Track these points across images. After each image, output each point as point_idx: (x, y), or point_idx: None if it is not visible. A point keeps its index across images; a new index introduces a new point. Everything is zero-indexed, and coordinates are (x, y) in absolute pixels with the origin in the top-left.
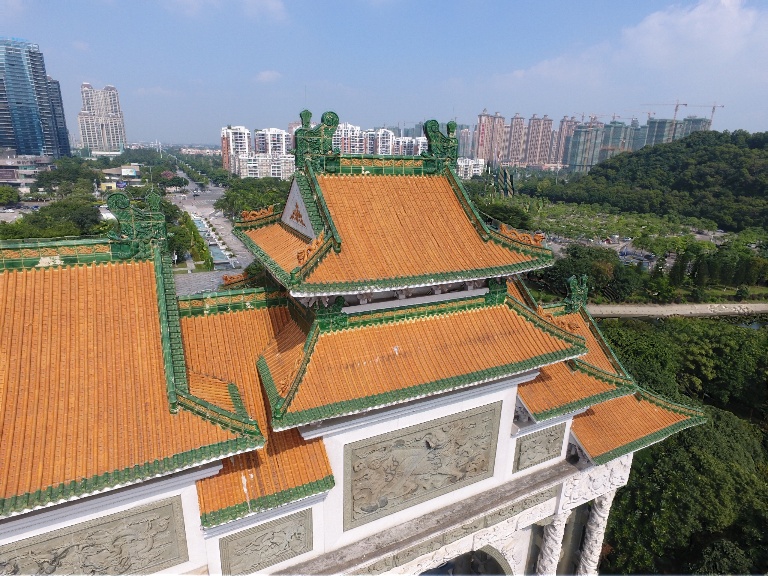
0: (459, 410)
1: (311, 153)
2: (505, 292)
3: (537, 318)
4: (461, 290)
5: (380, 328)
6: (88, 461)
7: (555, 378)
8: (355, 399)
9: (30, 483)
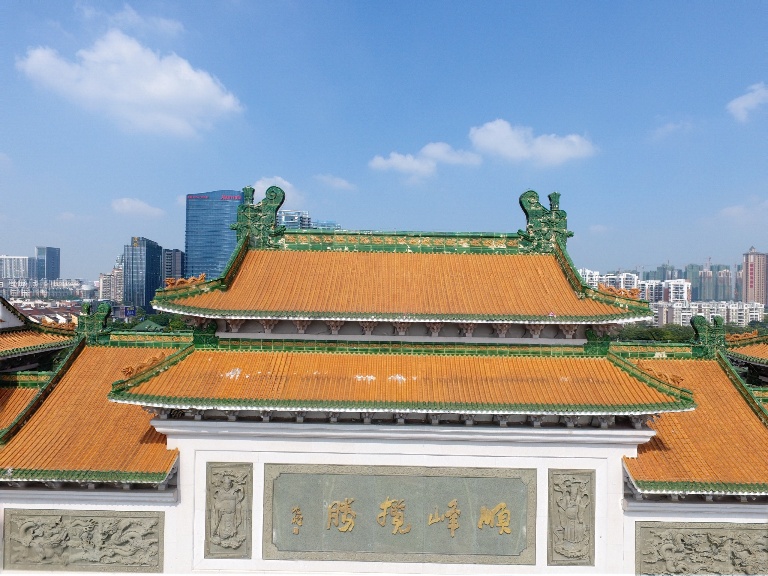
0: None
1: None
2: None
3: None
4: None
5: None
6: (762, 474)
7: None
8: None
9: (737, 478)
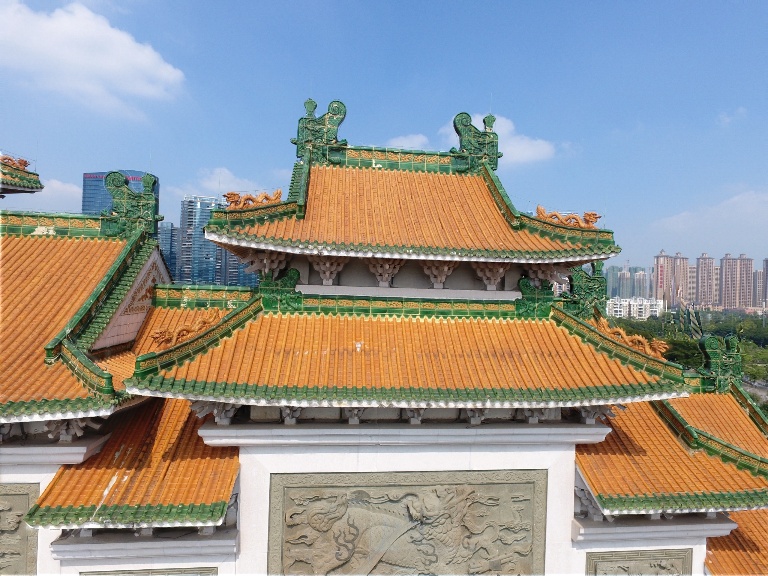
0: (465, 466)
1: (312, 142)
2: (550, 301)
3: (599, 337)
4: (477, 290)
5: (348, 320)
6: None
7: (653, 454)
8: (267, 386)
9: None
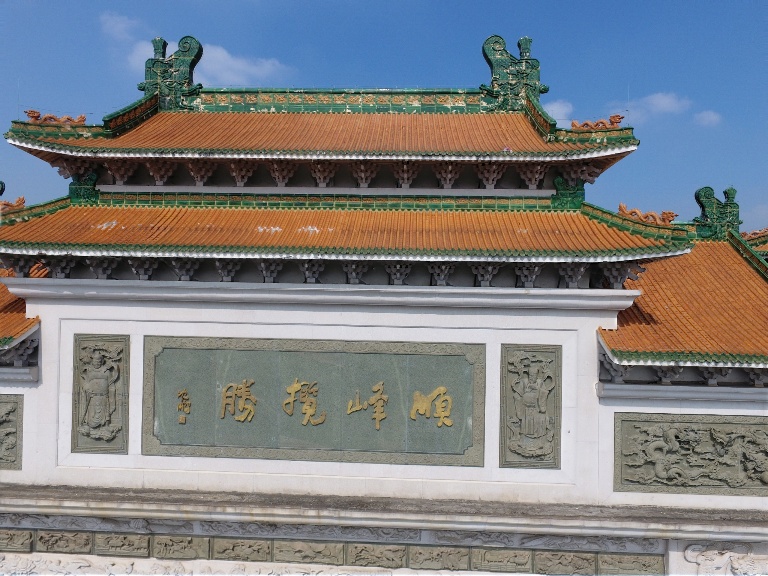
0: None
1: None
2: None
3: None
4: None
5: None
6: None
7: None
8: None
9: None
